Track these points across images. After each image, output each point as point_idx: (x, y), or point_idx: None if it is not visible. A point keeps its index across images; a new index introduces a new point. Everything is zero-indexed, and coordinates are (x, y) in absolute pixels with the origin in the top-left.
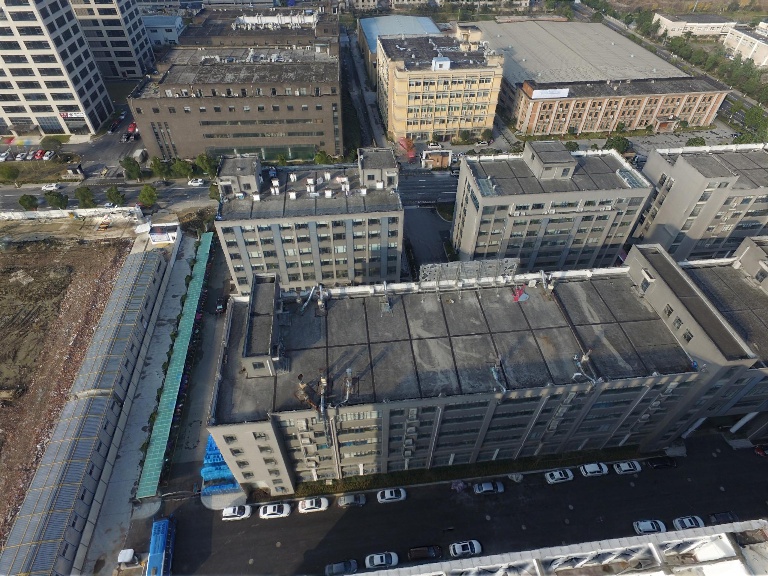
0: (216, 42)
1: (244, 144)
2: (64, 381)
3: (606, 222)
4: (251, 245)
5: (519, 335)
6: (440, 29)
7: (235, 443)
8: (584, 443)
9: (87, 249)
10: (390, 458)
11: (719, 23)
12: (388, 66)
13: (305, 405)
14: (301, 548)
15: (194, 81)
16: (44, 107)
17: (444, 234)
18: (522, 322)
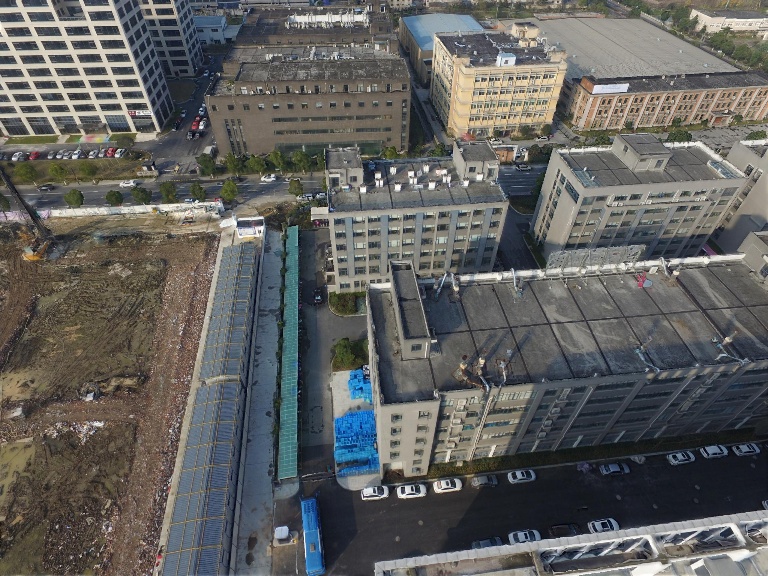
0: (273, 41)
1: (313, 140)
2: (182, 369)
3: (699, 212)
4: (358, 236)
5: (653, 319)
6: (483, 27)
7: (399, 422)
8: (704, 426)
9: (177, 243)
10: (524, 439)
11: (758, 18)
12: (454, 62)
13: (465, 385)
14: (443, 526)
15: (268, 78)
16: (113, 105)
17: (521, 227)
18: (653, 307)
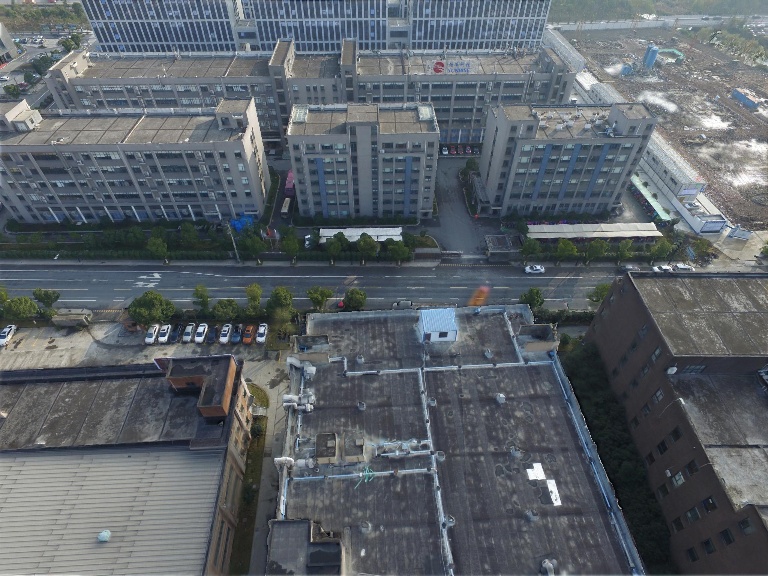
0: None
1: None
2: None
3: None
4: None
5: None
6: None
7: None
8: None
9: (767, 218)
10: None
11: None
12: None
13: None
14: None
15: None
16: None
17: (436, 223)
18: None
